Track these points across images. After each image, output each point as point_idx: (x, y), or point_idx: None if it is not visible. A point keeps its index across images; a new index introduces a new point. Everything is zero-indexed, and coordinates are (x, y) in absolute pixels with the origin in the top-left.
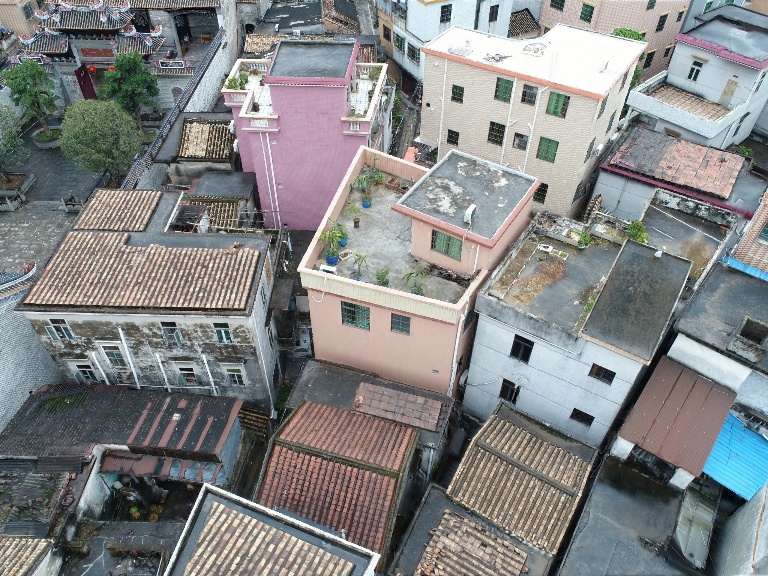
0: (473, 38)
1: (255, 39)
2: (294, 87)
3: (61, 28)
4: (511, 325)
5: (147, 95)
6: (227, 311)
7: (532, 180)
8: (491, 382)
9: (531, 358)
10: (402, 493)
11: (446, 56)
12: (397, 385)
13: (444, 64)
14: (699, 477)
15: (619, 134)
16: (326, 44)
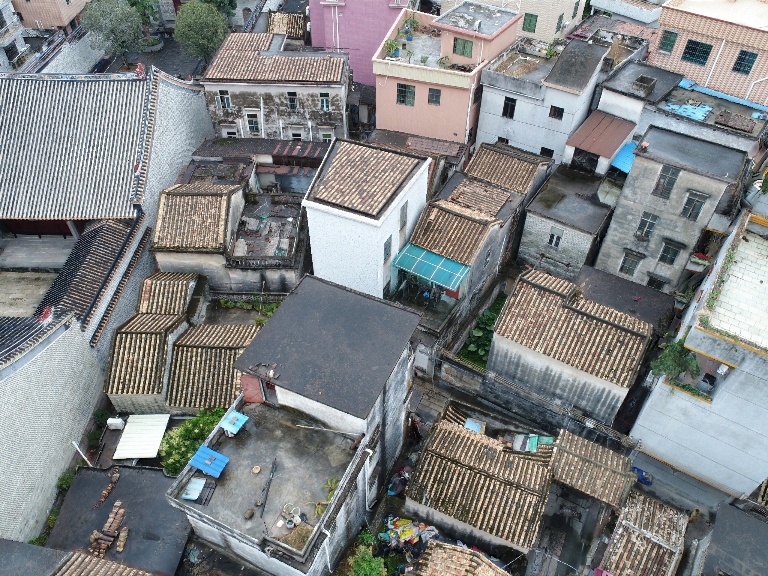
0: None
1: None
2: None
3: None
4: (502, 88)
5: (229, 8)
6: None
7: (516, 14)
8: (490, 142)
9: (515, 113)
10: (437, 181)
11: None
12: (432, 139)
13: None
14: (614, 173)
15: (583, 21)
16: None
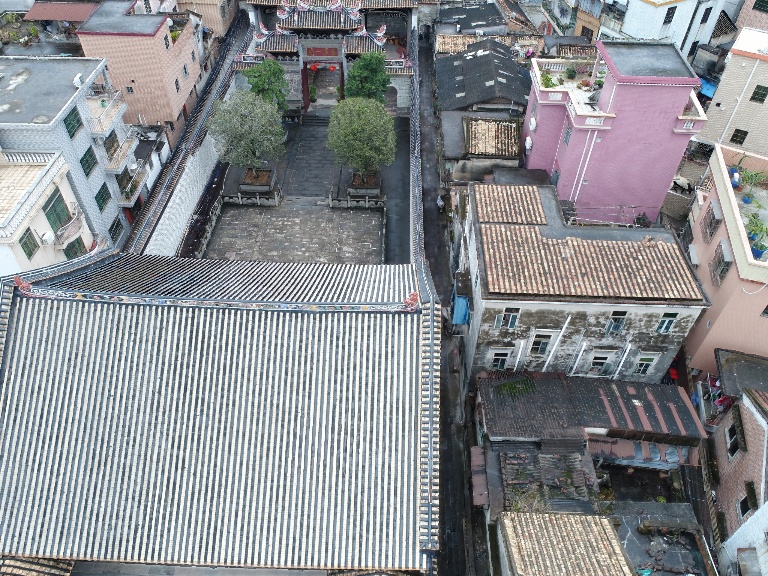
0: None
1: (446, 39)
2: (643, 86)
3: (299, 27)
4: None
5: None
6: (685, 301)
7: None
8: None
9: None
10: None
11: (760, 57)
12: None
13: (753, 65)
14: None
15: None
16: (644, 45)
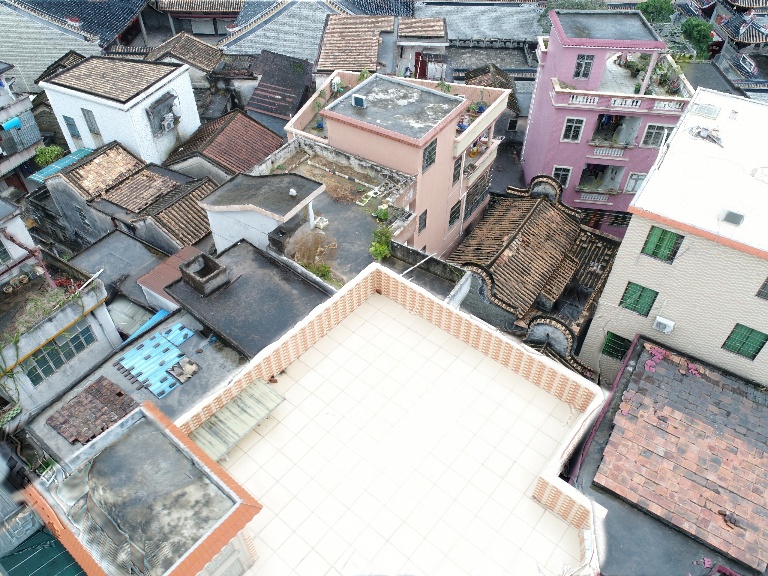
0: (762, 122)
1: None
2: None
3: None
4: None
5: None
6: None
7: None
8: None
9: None
10: None
11: None
12: None
13: None
14: None
15: (763, 385)
16: None
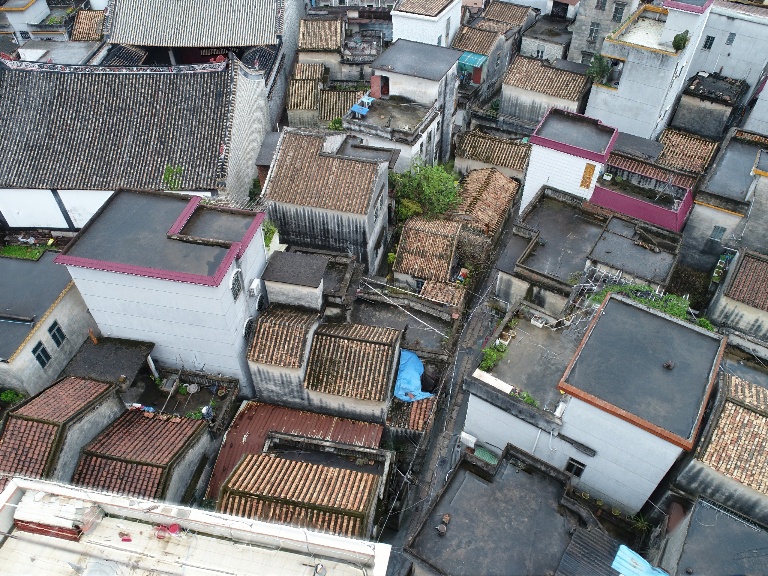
0: None
1: None
2: None
3: None
4: None
5: None
6: None
7: None
8: None
9: None
10: None
11: None
12: None
13: None
14: None
15: None
16: None
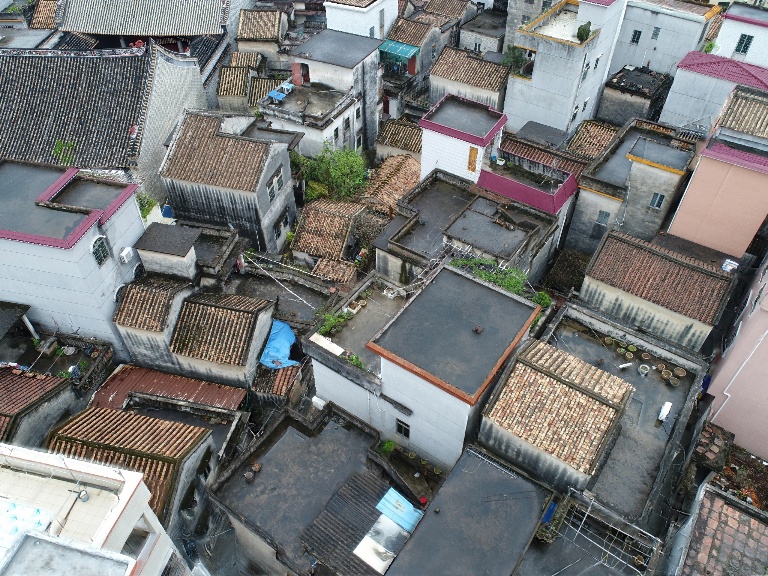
0: None
1: None
2: None
3: None
4: None
5: None
6: None
7: None
8: None
9: None
10: None
11: None
12: None
13: None
14: None
15: None
16: None
